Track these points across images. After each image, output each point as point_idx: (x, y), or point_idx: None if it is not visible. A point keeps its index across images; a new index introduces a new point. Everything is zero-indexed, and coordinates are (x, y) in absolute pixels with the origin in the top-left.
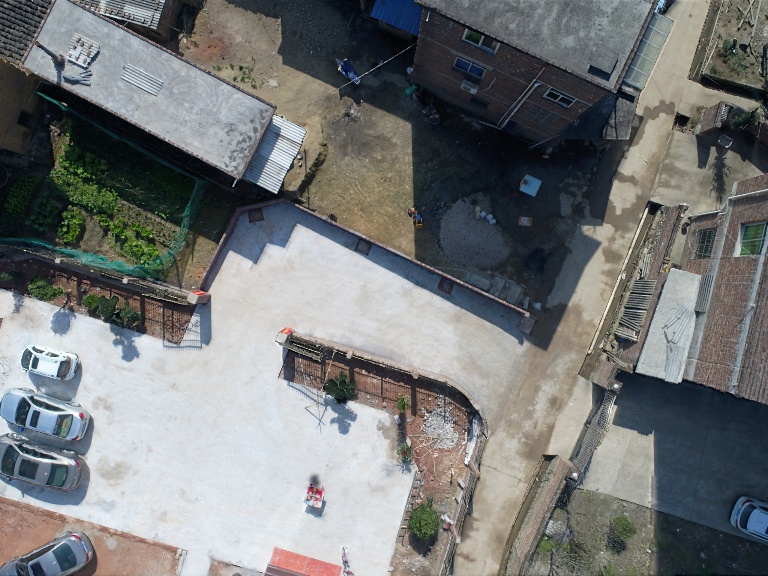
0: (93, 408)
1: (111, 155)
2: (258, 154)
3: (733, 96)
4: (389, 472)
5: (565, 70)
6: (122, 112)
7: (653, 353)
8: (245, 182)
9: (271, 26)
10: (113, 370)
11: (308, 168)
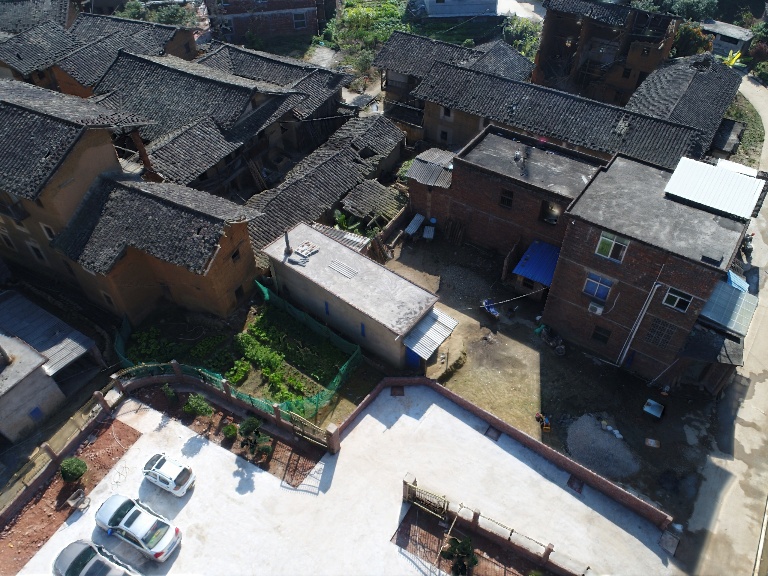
0: (186, 535)
1: (290, 331)
2: (417, 329)
3: None
4: None
5: (683, 256)
6: (322, 284)
7: None
8: (393, 367)
9: (432, 280)
10: (223, 499)
11: (449, 365)
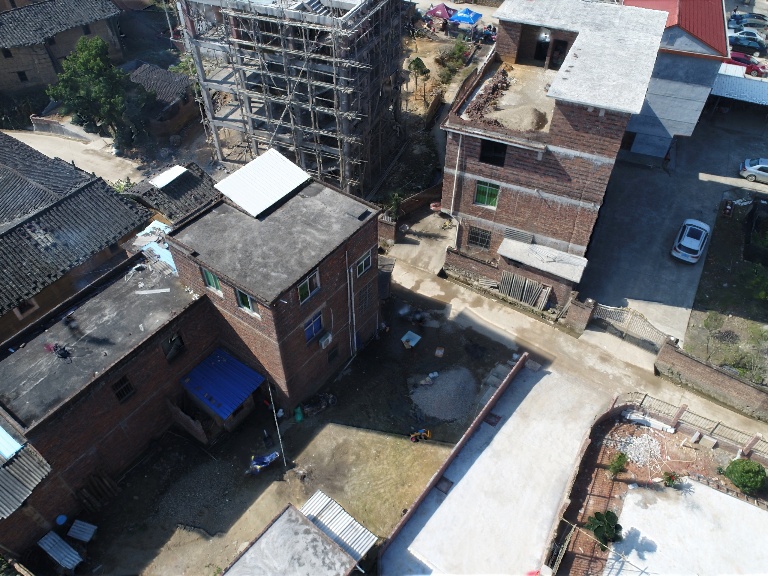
0: None
1: None
2: None
3: None
4: (695, 506)
5: (357, 230)
6: None
7: (563, 271)
8: None
9: (181, 538)
10: None
11: None
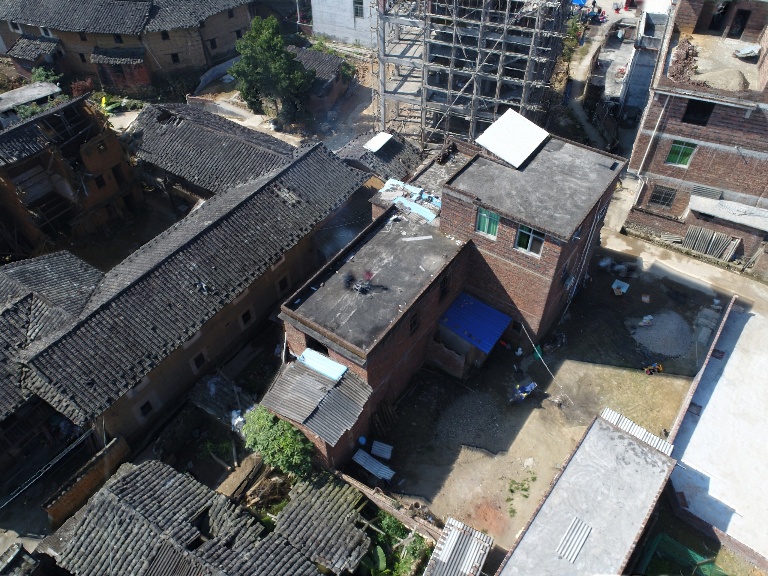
0: None
1: None
2: None
3: None
4: None
5: None
6: (614, 572)
7: (757, 222)
8: None
9: (468, 456)
10: None
11: None
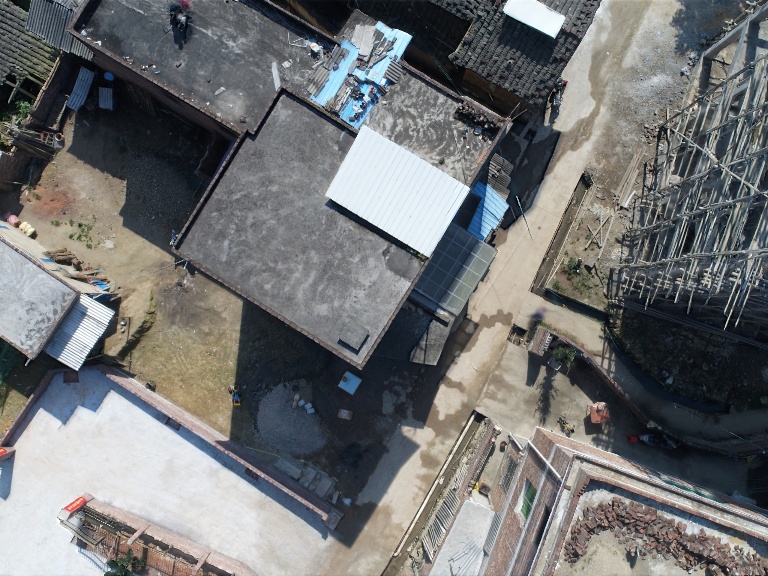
0: None
1: None
2: (62, 331)
3: (574, 314)
4: None
5: None
6: None
7: None
8: None
9: (117, 187)
10: None
11: (130, 335)
